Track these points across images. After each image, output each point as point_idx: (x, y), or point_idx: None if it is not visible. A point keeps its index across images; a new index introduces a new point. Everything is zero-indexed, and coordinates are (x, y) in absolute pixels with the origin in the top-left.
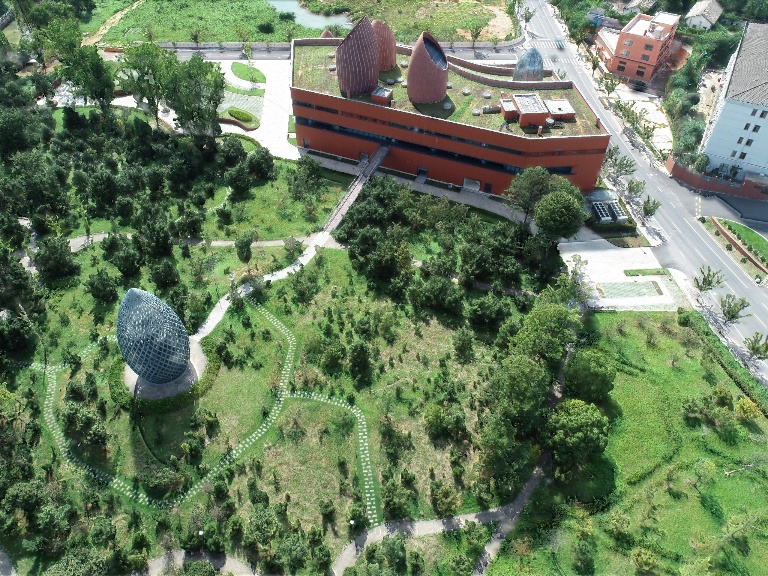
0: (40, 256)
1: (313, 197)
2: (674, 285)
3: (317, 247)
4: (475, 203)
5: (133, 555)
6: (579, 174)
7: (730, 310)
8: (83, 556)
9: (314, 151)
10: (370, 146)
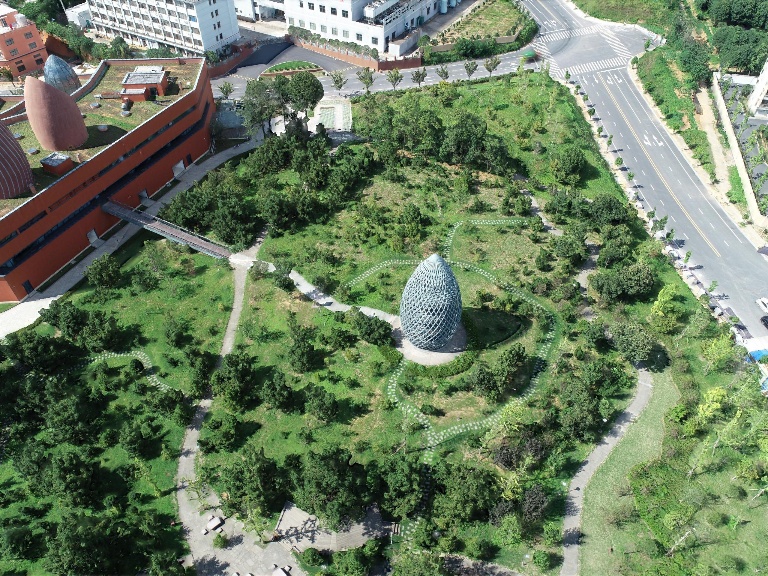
0: (260, 486)
1: (157, 273)
2: (326, 102)
3: (270, 248)
4: (202, 173)
5: (600, 318)
6: (210, 101)
7: (367, 77)
8: (619, 329)
9: (42, 285)
10: (92, 217)
